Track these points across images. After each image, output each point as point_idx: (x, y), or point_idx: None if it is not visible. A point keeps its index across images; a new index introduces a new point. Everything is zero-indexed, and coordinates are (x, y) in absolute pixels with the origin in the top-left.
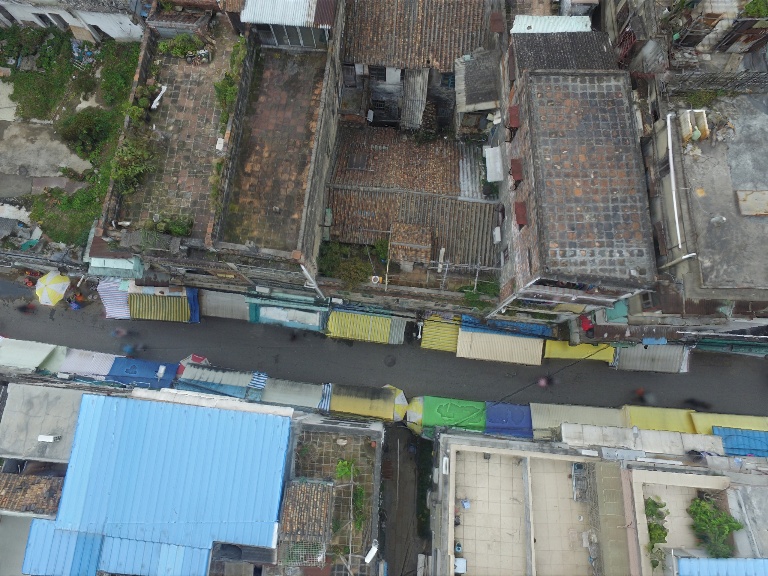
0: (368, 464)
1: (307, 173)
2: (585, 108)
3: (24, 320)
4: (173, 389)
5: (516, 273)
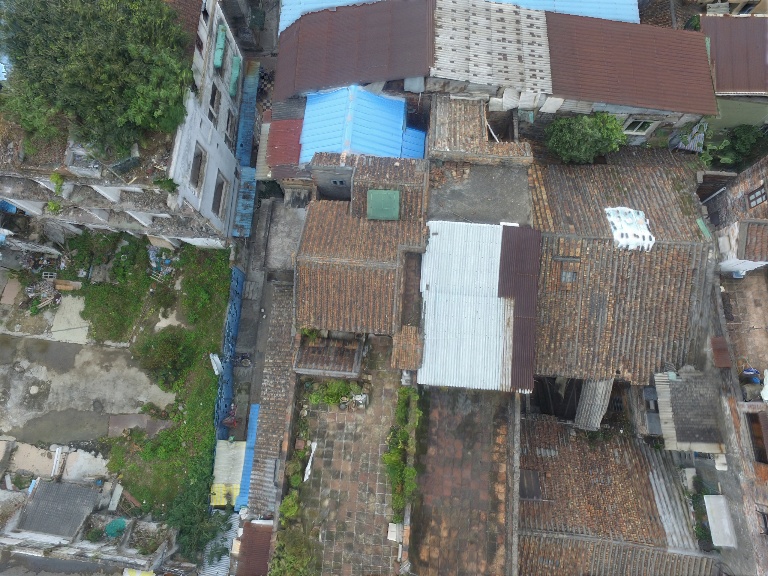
0: None
1: (499, 561)
2: None
3: None
4: None
5: None
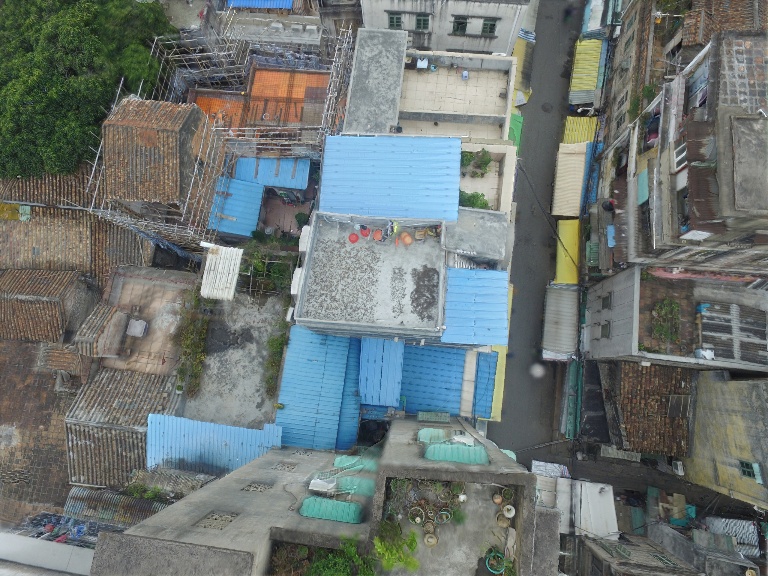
0: None
1: None
2: None
3: None
4: None
5: None
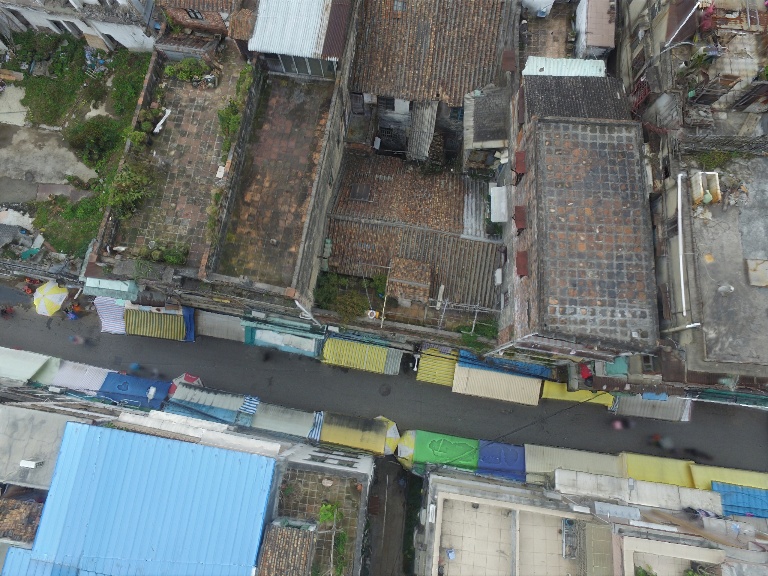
0: (353, 507)
1: (307, 206)
2: (594, 159)
3: (21, 327)
4: (162, 412)
5: (515, 321)
